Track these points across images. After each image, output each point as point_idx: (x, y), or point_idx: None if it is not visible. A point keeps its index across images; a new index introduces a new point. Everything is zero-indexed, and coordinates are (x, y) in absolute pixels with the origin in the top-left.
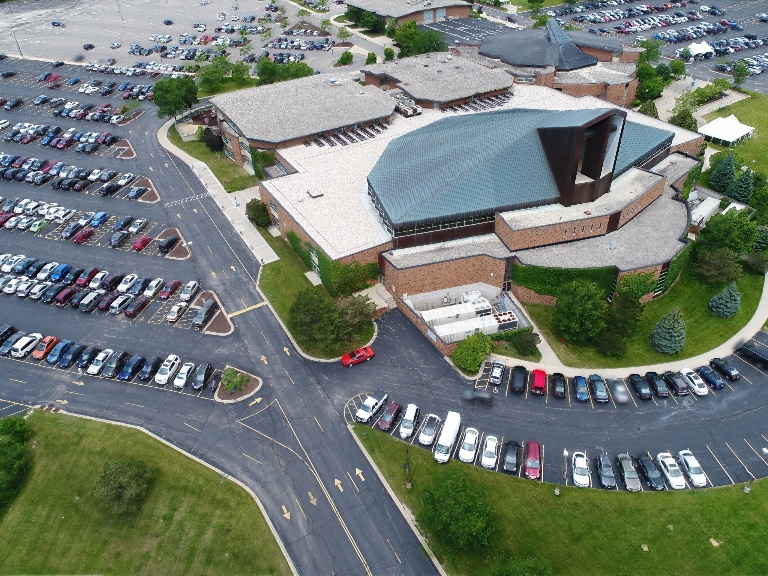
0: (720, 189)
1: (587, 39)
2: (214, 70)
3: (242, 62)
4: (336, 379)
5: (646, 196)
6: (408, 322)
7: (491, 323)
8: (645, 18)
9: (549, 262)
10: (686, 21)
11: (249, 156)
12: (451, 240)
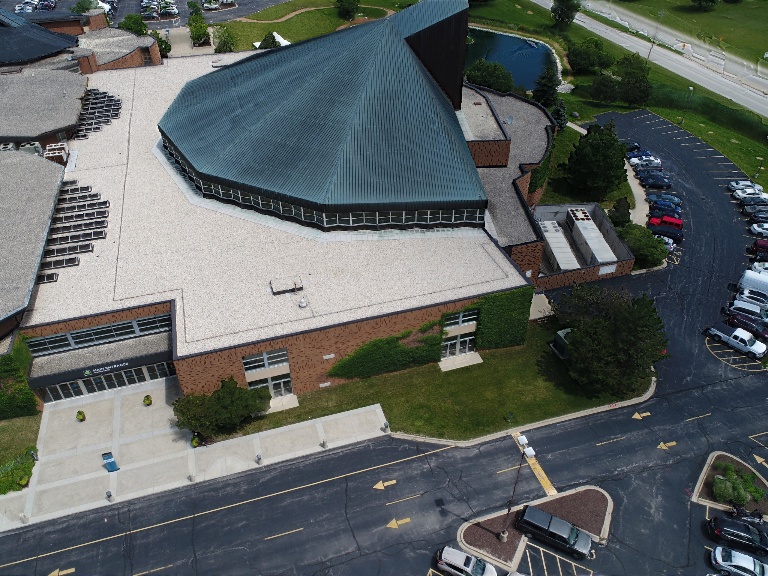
0: None
1: (30, 15)
2: None
3: None
4: (689, 369)
5: None
6: (567, 289)
7: (592, 224)
8: None
9: (531, 153)
10: None
11: None
12: None
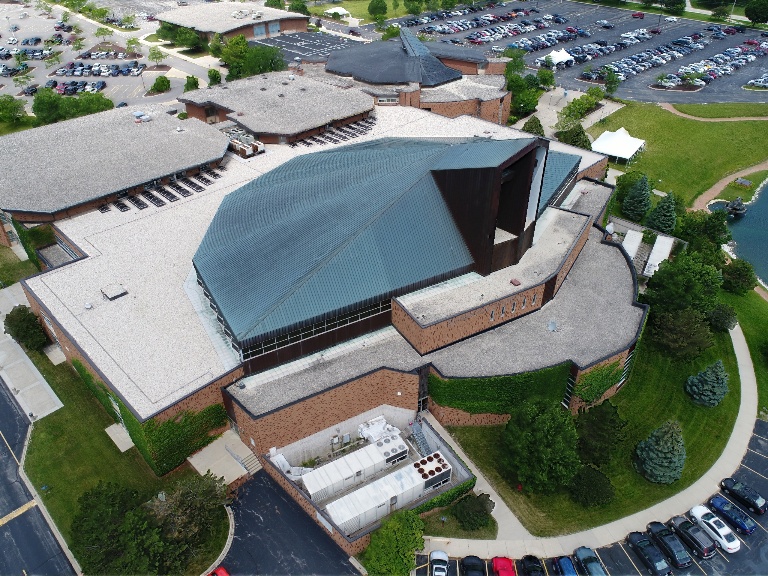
0: (636, 218)
1: (447, 50)
2: None
3: (11, 96)
4: None
5: (577, 246)
6: (283, 496)
7: (413, 482)
8: (494, 27)
9: (479, 366)
10: (534, 29)
11: (16, 233)
12: (331, 346)
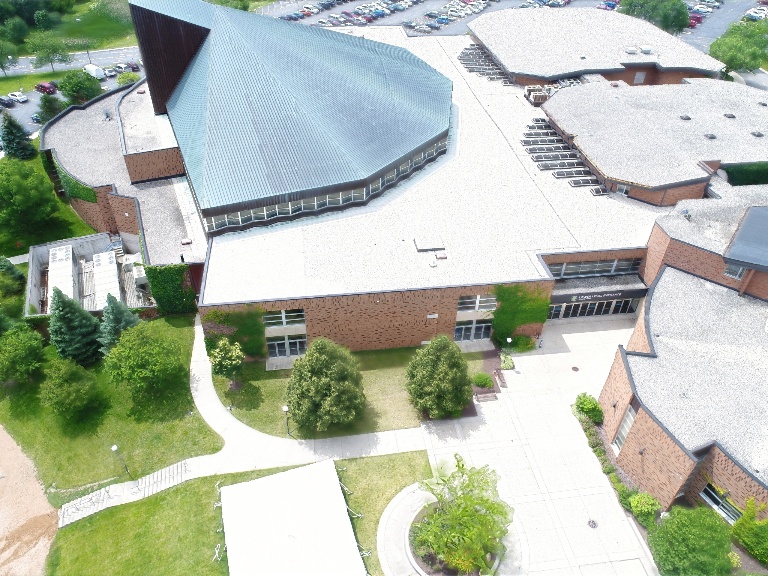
0: None
1: None
2: (762, 26)
3: None
4: None
5: None
6: None
7: None
8: None
9: None
10: None
11: None
12: None
